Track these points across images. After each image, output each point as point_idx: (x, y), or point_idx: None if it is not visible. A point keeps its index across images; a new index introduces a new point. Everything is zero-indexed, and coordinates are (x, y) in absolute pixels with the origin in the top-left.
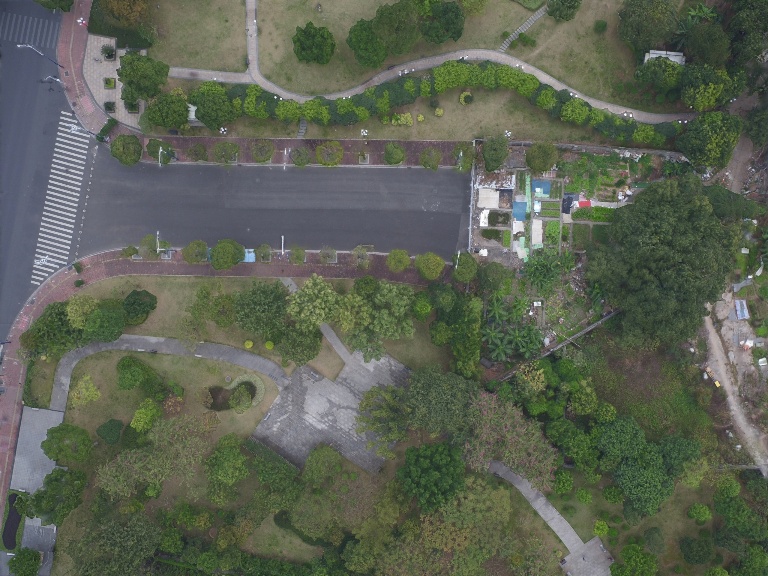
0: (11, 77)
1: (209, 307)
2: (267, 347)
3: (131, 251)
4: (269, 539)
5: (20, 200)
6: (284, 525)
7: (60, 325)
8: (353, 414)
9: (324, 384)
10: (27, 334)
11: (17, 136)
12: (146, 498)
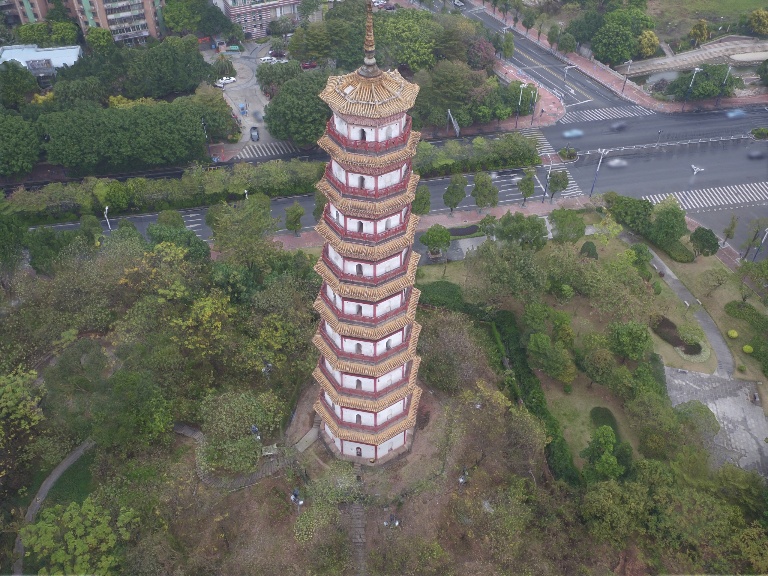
0: (762, 155)
1: (764, 269)
2: (745, 347)
3: (734, 229)
4: (571, 411)
5: (691, 178)
6: (598, 417)
7: (641, 207)
8: (754, 446)
9: (755, 409)
10: (616, 193)
11: (730, 166)
12: (557, 288)
